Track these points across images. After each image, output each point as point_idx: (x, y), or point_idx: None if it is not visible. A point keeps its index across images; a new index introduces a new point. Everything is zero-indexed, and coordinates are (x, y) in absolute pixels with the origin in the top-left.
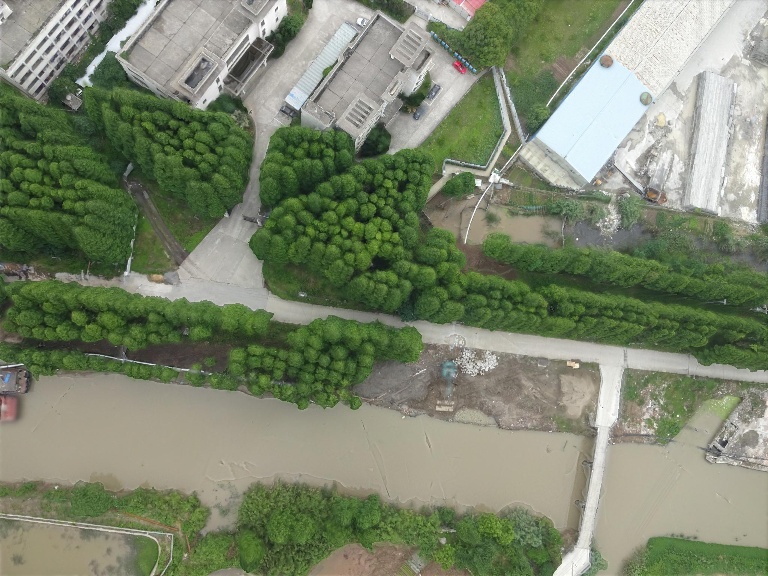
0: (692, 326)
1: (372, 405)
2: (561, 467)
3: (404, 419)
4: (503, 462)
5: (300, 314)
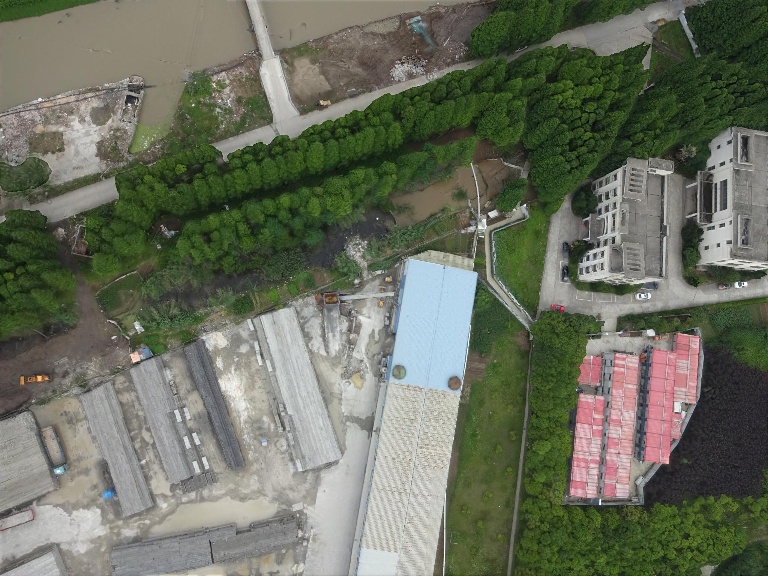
0: (264, 153)
1: (467, 3)
2: (272, 28)
3: (437, 3)
4: (333, 5)
5: (560, 42)
